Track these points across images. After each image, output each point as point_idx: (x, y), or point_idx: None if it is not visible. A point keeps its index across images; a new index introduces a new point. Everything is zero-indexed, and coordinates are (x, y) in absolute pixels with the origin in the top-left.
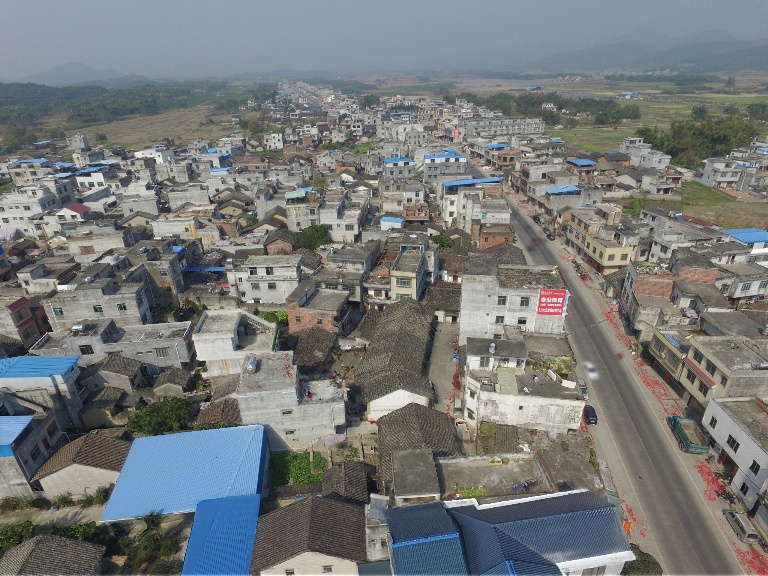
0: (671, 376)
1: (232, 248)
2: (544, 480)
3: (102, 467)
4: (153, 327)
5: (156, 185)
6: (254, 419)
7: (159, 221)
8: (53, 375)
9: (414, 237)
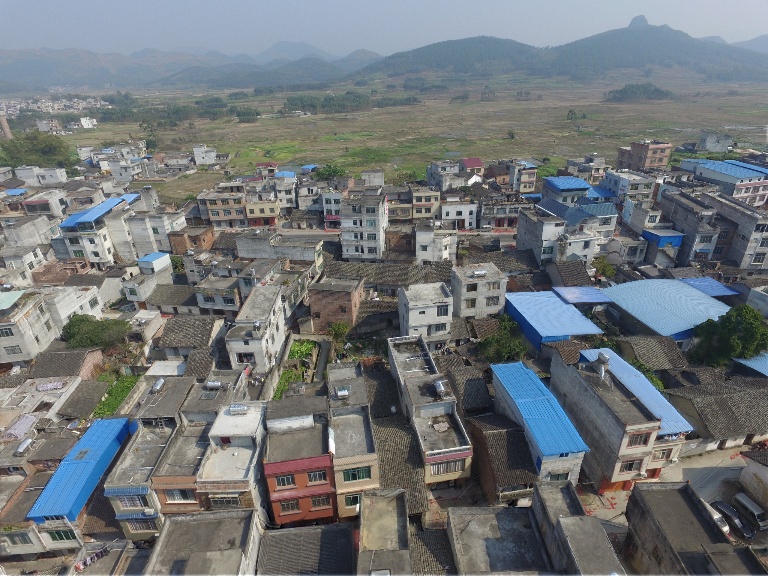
0: (408, 219)
1: (49, 416)
2: (531, 212)
3: None
4: None
5: None
6: None
7: None
8: None
9: (259, 232)
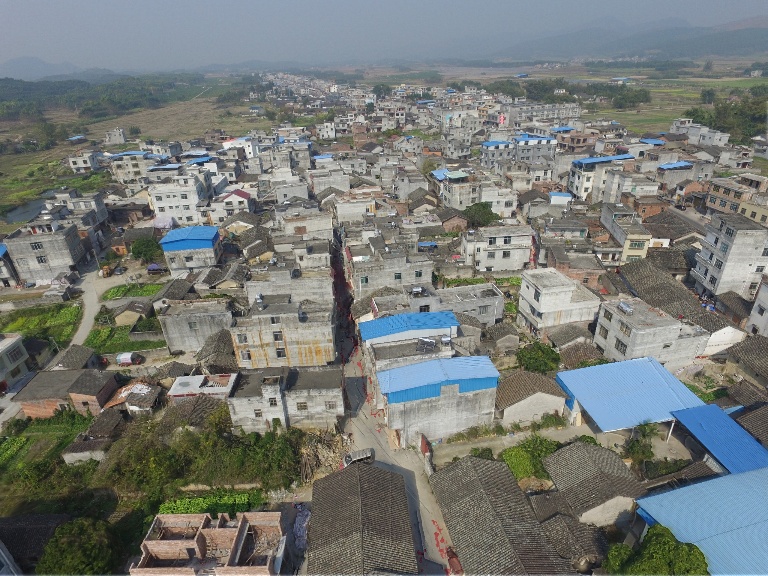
0: None
1: (413, 226)
2: None
3: (557, 394)
4: (460, 289)
5: (294, 171)
6: (641, 353)
7: (344, 203)
8: (451, 326)
9: (621, 206)
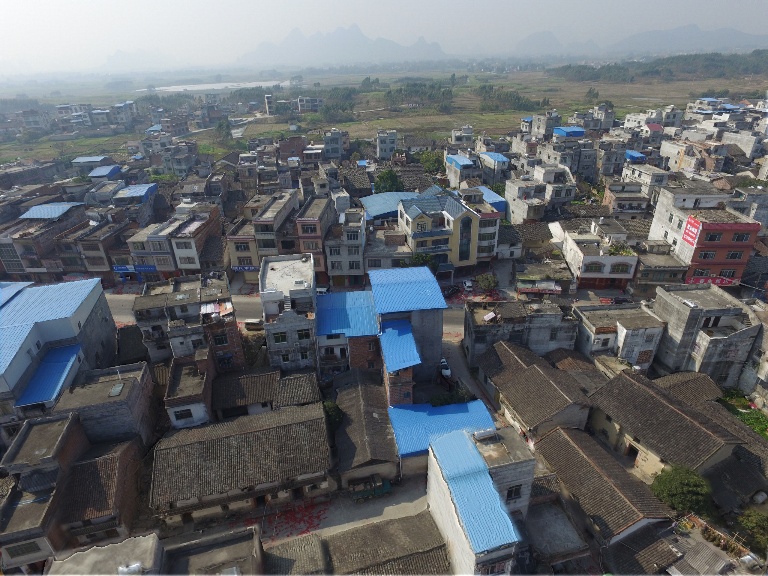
0: None
1: None
2: None
3: (468, 185)
4: None
5: None
6: None
7: (667, 142)
8: None
9: (759, 188)
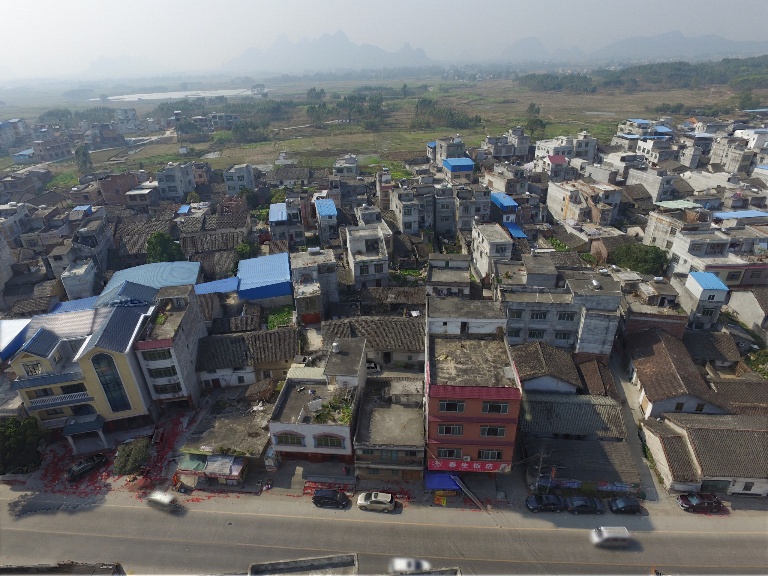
0: None
1: (570, 229)
2: None
3: (270, 251)
4: None
5: None
6: None
7: (553, 183)
8: None
9: (594, 284)
